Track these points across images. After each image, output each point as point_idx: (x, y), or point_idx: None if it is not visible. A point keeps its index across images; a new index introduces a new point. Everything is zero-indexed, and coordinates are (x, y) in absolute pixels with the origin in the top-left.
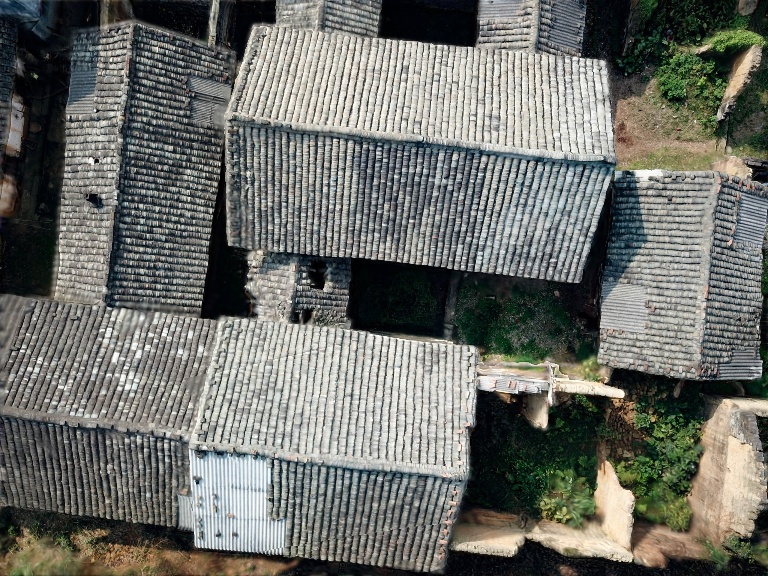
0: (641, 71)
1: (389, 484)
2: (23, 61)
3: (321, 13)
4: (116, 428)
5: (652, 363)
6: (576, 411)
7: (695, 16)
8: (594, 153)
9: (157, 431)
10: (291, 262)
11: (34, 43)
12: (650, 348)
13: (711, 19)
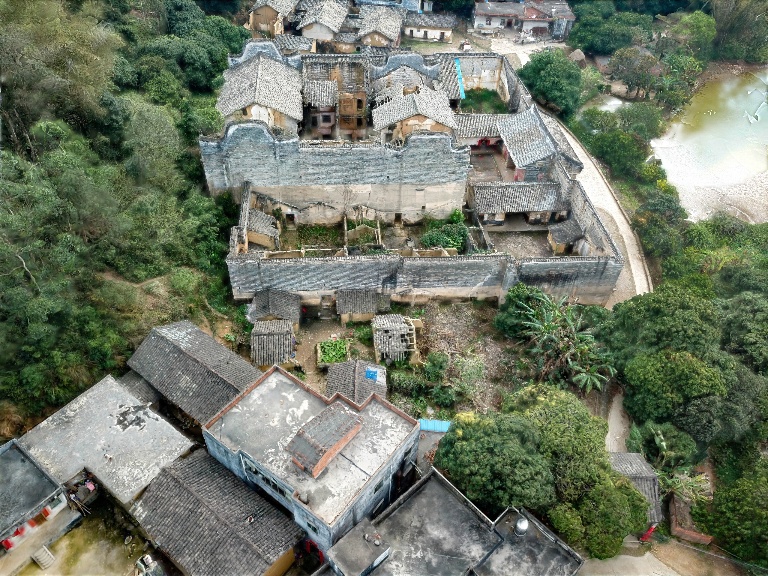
0: None
1: None
2: None
3: None
4: None
5: None
6: None
7: None
8: None
9: None
10: None
11: None
12: None
13: None
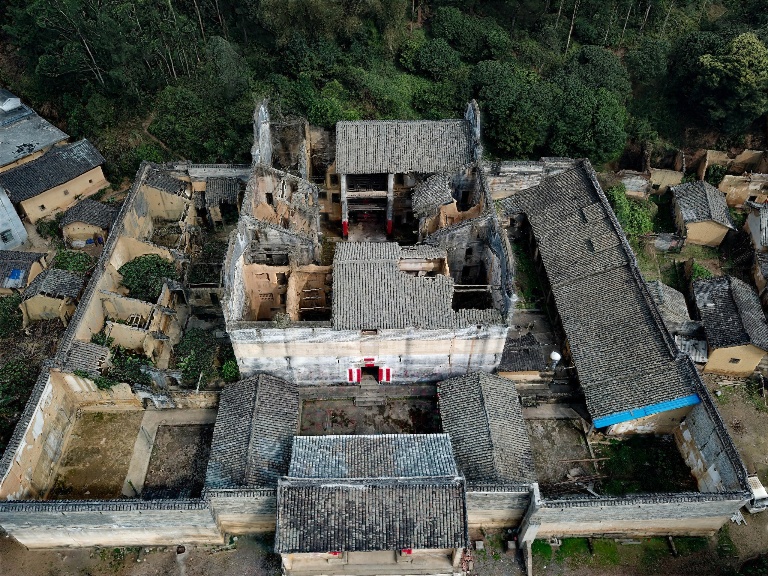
0: None
1: None
2: None
3: None
4: None
5: None
6: None
7: None
8: (767, 210)
9: None
10: None
11: None
12: None
13: None
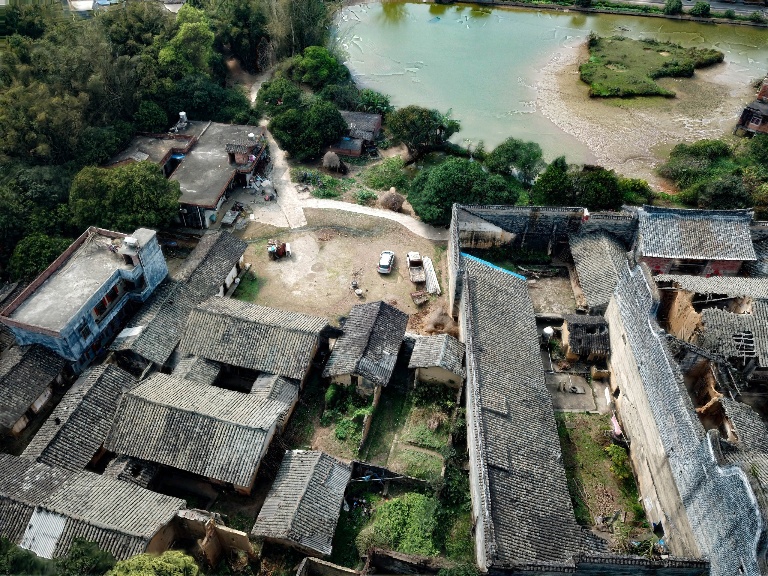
0: (330, 425)
1: (114, 541)
2: (62, 377)
3: (187, 374)
4: (10, 497)
5: (271, 531)
6: (244, 575)
7: (352, 405)
8: None
9: (26, 502)
10: (126, 461)
11: (70, 372)
12: (273, 525)
13: (362, 408)
